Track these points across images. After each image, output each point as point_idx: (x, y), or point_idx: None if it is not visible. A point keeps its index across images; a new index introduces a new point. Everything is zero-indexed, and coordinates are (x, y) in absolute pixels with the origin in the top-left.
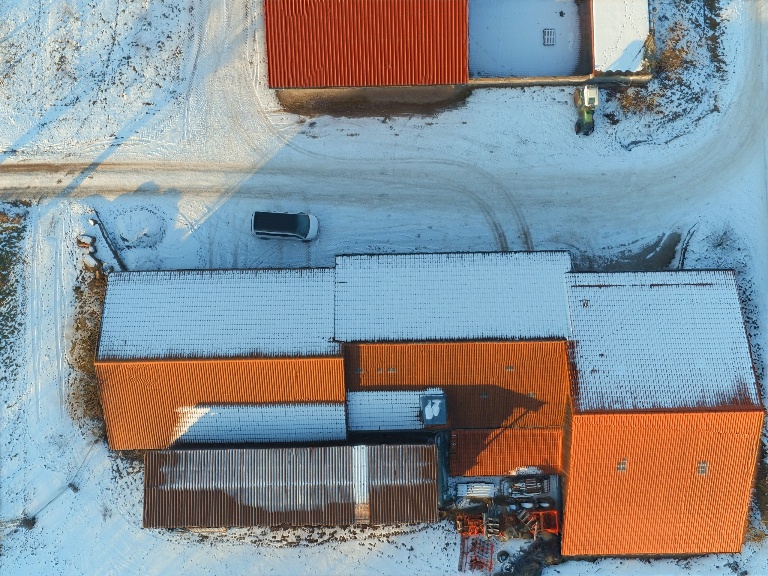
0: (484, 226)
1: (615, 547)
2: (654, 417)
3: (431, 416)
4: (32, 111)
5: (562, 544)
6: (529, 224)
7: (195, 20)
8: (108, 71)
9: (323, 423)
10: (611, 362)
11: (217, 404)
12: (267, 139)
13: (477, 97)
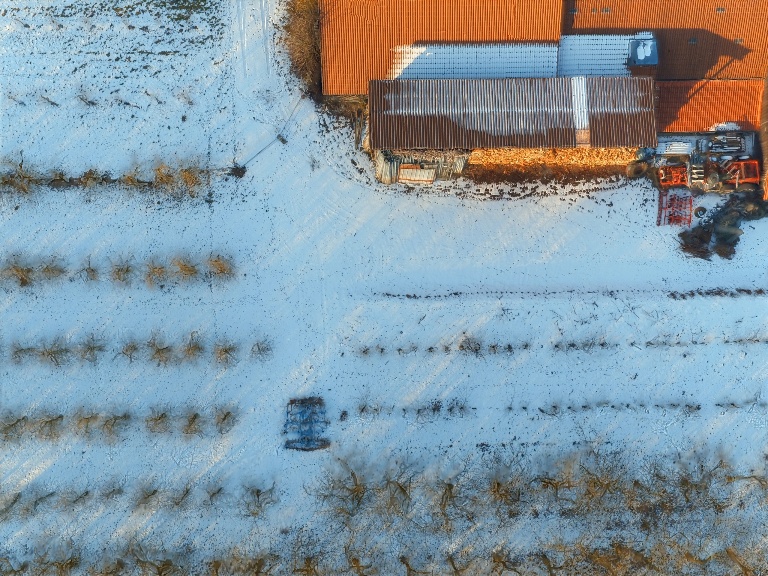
0: None
1: None
2: None
3: (643, 56)
4: None
5: (766, 187)
6: None
7: None
8: None
9: (535, 66)
10: None
11: (433, 43)
12: None
13: None
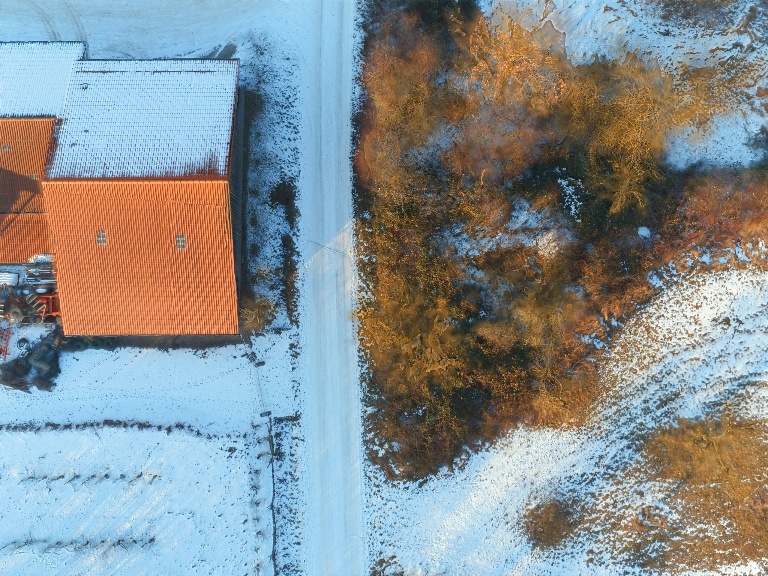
0: (43, 35)
1: (115, 327)
2: (122, 186)
3: None
4: None
5: None
6: (88, 34)
7: None
8: None
9: None
10: (94, 137)
11: None
12: None
13: None
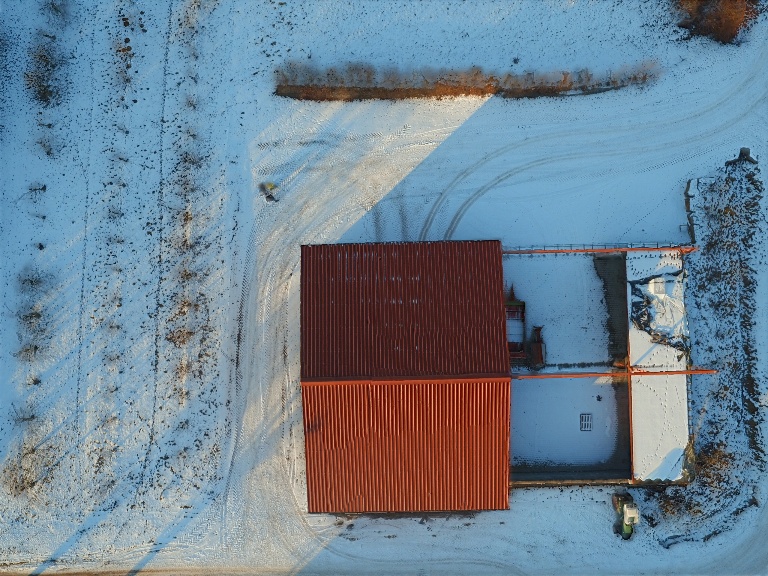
0: None
1: None
2: None
3: None
4: (71, 517)
5: None
6: None
7: (232, 414)
8: (146, 473)
9: None
10: None
11: None
12: (304, 542)
13: (514, 497)
